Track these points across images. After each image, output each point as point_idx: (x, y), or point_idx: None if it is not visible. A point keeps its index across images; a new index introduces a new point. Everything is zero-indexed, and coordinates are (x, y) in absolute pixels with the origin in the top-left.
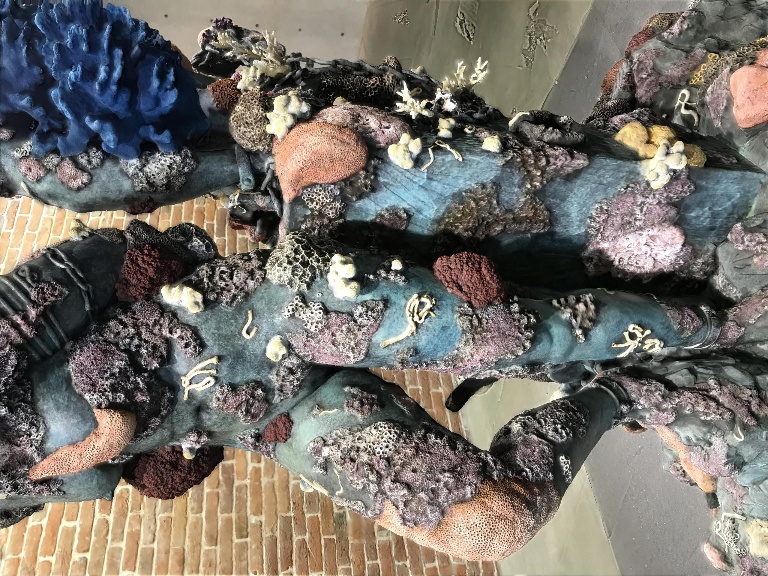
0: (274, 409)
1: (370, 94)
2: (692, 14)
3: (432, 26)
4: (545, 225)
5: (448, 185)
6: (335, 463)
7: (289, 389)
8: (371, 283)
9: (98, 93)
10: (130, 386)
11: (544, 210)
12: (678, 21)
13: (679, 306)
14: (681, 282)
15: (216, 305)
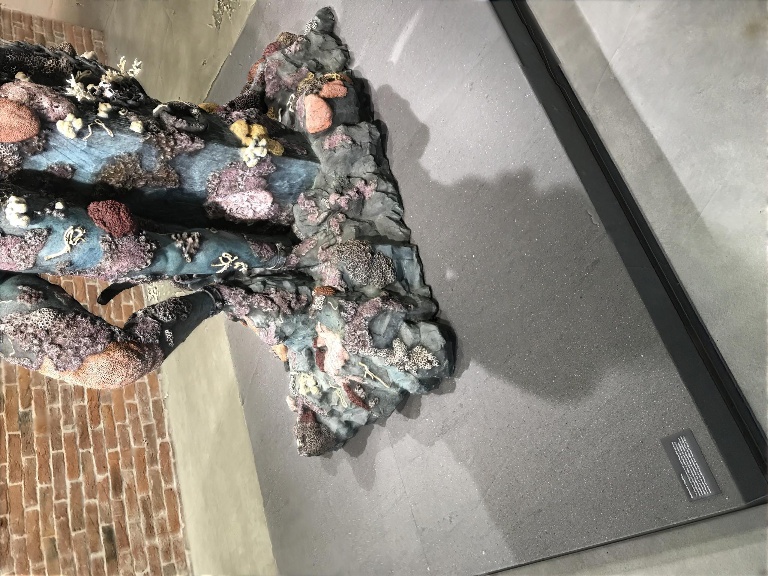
0: None
1: (47, 71)
2: (303, 40)
3: None
4: (176, 183)
5: (103, 151)
6: (9, 334)
7: None
8: (39, 217)
9: None
10: None
11: (175, 174)
12: (294, 43)
13: (260, 243)
14: (273, 227)
15: None
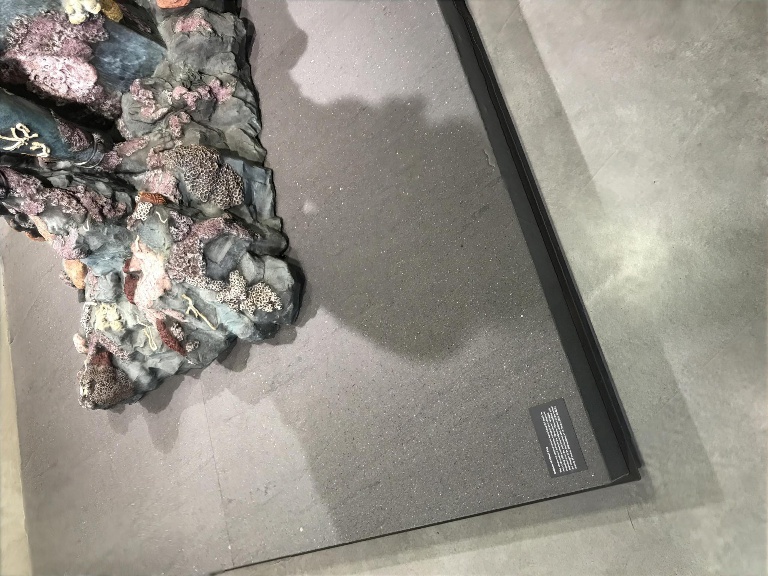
0: None
1: None
2: None
3: None
4: None
5: None
6: None
7: None
8: None
9: None
10: None
11: None
12: None
13: (72, 126)
14: (91, 115)
15: None
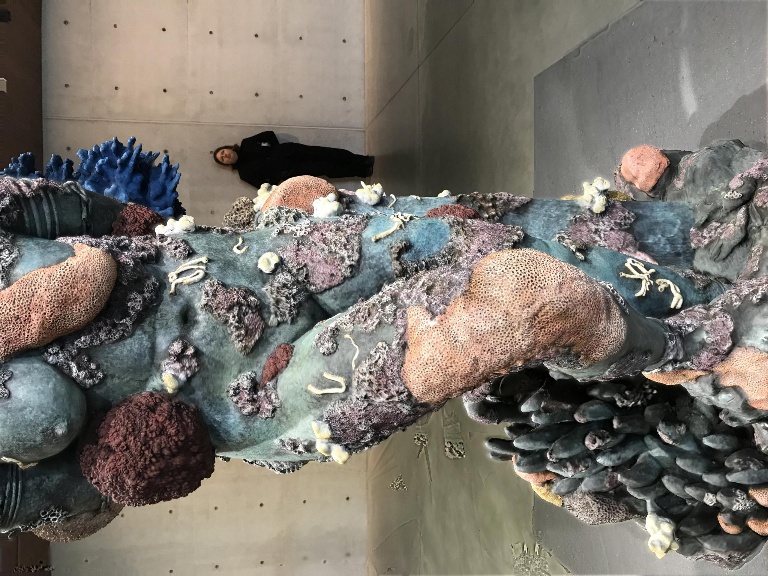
0: (271, 337)
1: None
2: None
3: (427, 476)
4: None
5: None
6: (344, 325)
7: (286, 307)
8: None
9: (118, 171)
10: (115, 249)
11: None
12: None
13: None
14: None
15: (207, 233)
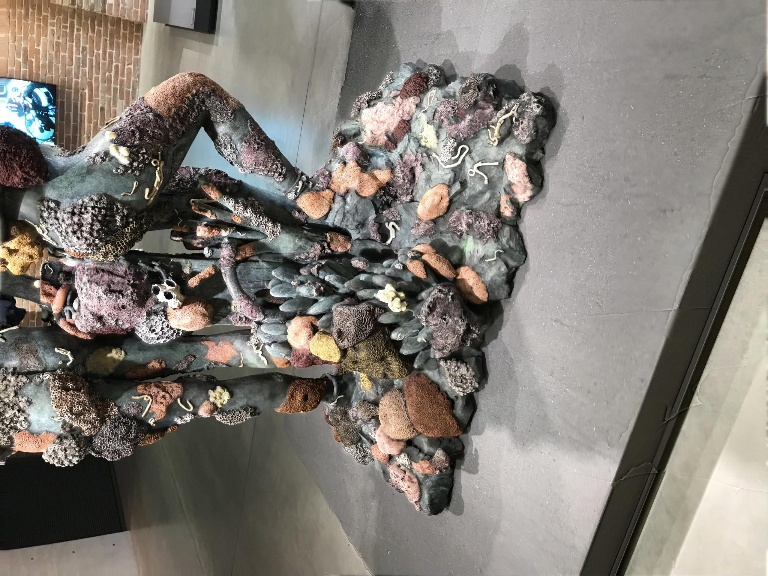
0: None
1: None
2: None
3: None
4: None
5: None
6: None
7: None
8: None
9: None
10: None
11: None
12: None
13: None
14: None
15: None
